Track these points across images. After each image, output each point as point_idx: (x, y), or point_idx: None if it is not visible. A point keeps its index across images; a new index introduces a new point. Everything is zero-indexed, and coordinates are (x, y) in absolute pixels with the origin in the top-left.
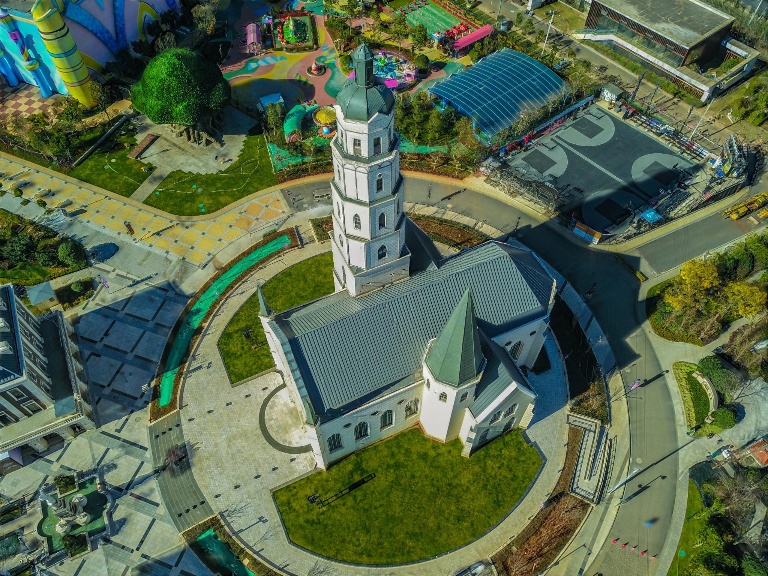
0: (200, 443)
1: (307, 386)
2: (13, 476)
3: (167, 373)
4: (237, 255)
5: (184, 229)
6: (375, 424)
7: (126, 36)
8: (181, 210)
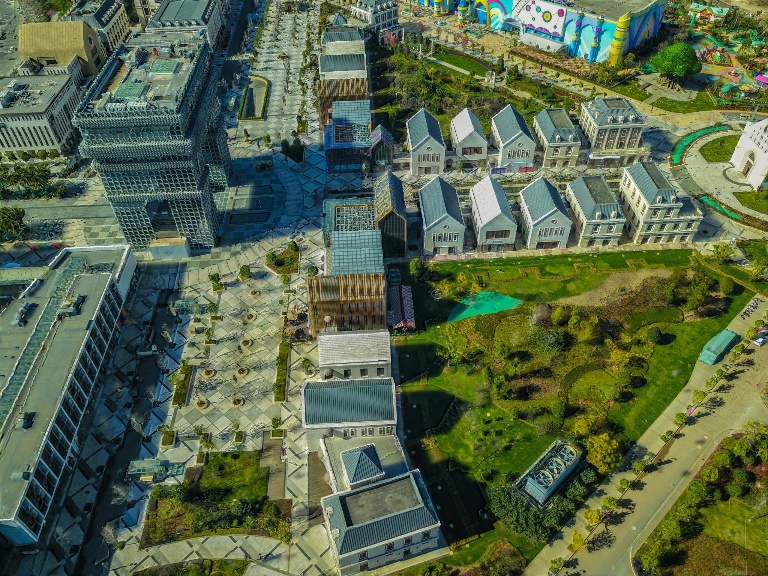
0: (696, 175)
1: None
2: (614, 169)
3: (676, 155)
4: (702, 128)
5: (673, 116)
6: None
7: (636, 42)
8: (670, 110)
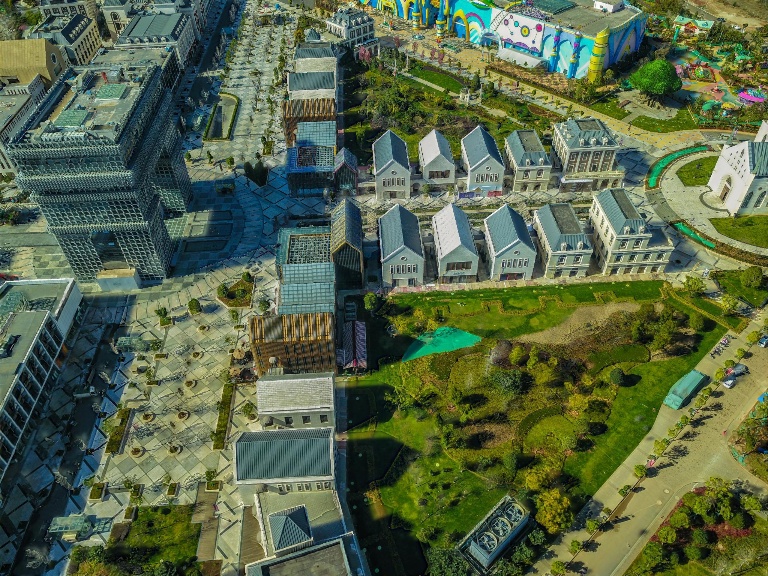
0: (672, 199)
1: (752, 163)
2: (587, 193)
3: (652, 178)
4: None
5: (651, 136)
6: (767, 198)
7: None
8: (648, 129)
